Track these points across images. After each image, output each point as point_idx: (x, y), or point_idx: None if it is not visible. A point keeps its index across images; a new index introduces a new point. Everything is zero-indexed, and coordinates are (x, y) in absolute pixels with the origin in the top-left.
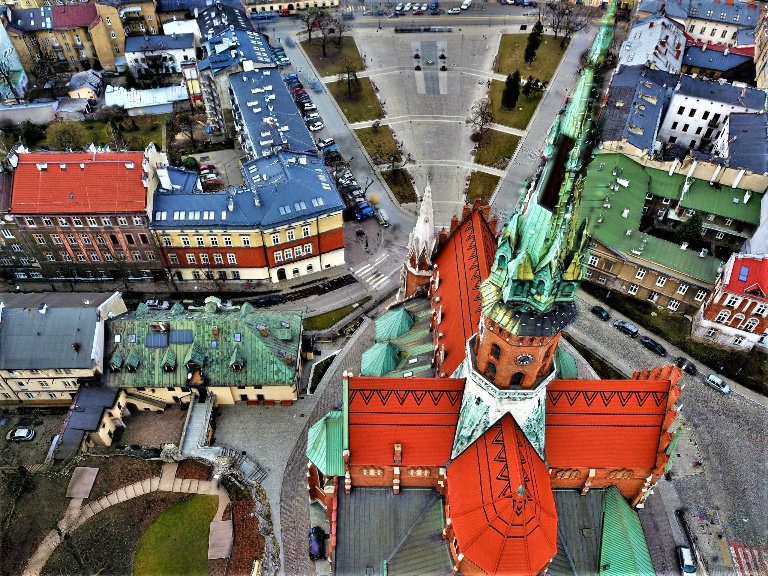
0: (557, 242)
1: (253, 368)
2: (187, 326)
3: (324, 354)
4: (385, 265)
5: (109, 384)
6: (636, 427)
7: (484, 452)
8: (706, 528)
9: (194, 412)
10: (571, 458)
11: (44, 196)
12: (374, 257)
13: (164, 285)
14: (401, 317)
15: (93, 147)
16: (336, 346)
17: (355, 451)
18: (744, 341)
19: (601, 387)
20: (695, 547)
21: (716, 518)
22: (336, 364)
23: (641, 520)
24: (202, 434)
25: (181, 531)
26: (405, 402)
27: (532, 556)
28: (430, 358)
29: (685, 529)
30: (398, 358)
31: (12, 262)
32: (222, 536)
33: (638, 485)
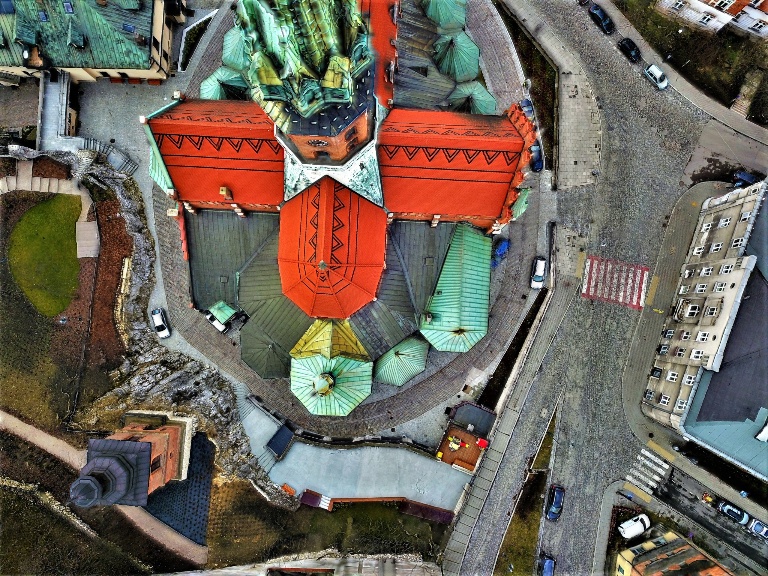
0: (289, 55)
1: (98, 47)
2: None
3: (198, 15)
4: None
5: None
6: (482, 182)
7: (305, 208)
8: (572, 240)
9: (47, 94)
10: (412, 205)
11: None
12: None
13: None
14: None
15: None
16: (212, 4)
17: (182, 188)
18: (713, 20)
19: (444, 144)
20: (552, 259)
21: (586, 231)
22: (211, 31)
23: (510, 230)
24: (59, 122)
25: (48, 230)
26: (221, 148)
27: (345, 304)
28: None
29: (550, 241)
30: None
31: None
32: (88, 236)
33: (490, 222)
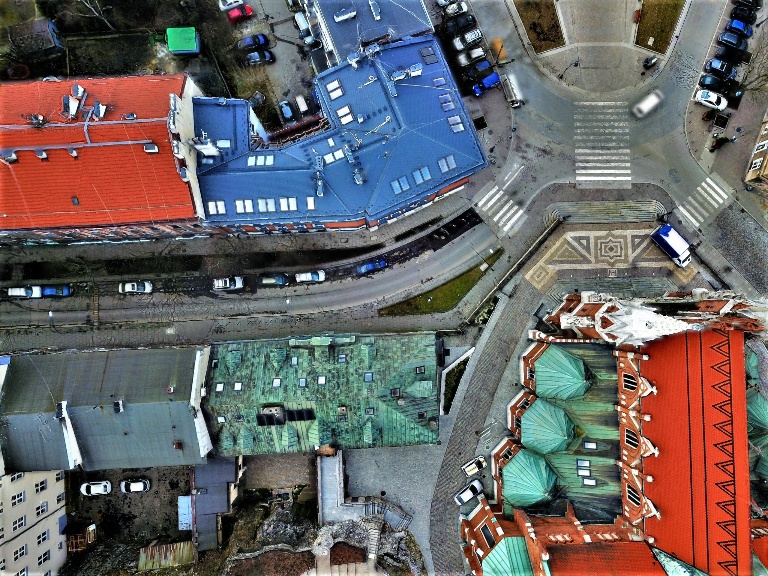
0: None
1: (390, 433)
2: (306, 406)
3: (453, 353)
4: (518, 187)
5: (223, 455)
6: None
7: None
8: None
9: (323, 463)
10: None
11: (33, 203)
12: (503, 172)
13: (225, 242)
14: (578, 387)
15: (73, 102)
16: (467, 341)
17: None
18: None
19: None
20: None
21: None
22: (470, 370)
23: None
24: (339, 492)
25: None
26: None
27: None
28: (614, 450)
29: None
30: (571, 440)
31: (12, 241)
32: None
33: None
